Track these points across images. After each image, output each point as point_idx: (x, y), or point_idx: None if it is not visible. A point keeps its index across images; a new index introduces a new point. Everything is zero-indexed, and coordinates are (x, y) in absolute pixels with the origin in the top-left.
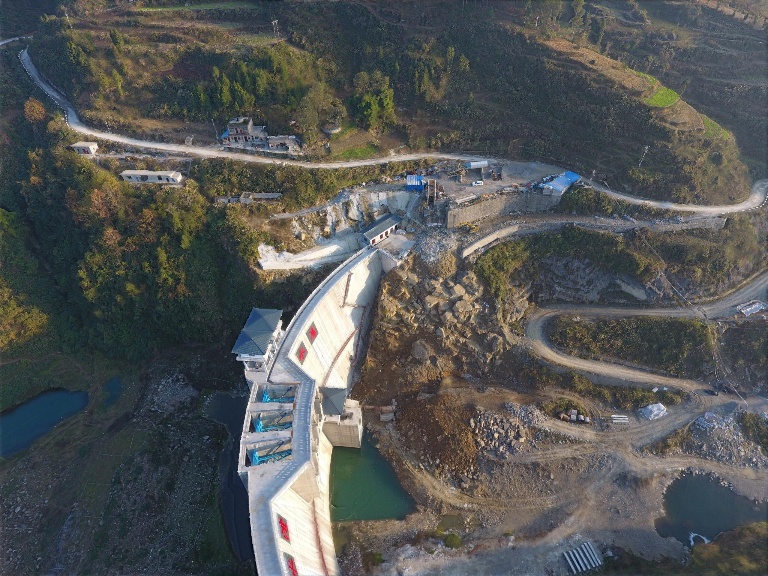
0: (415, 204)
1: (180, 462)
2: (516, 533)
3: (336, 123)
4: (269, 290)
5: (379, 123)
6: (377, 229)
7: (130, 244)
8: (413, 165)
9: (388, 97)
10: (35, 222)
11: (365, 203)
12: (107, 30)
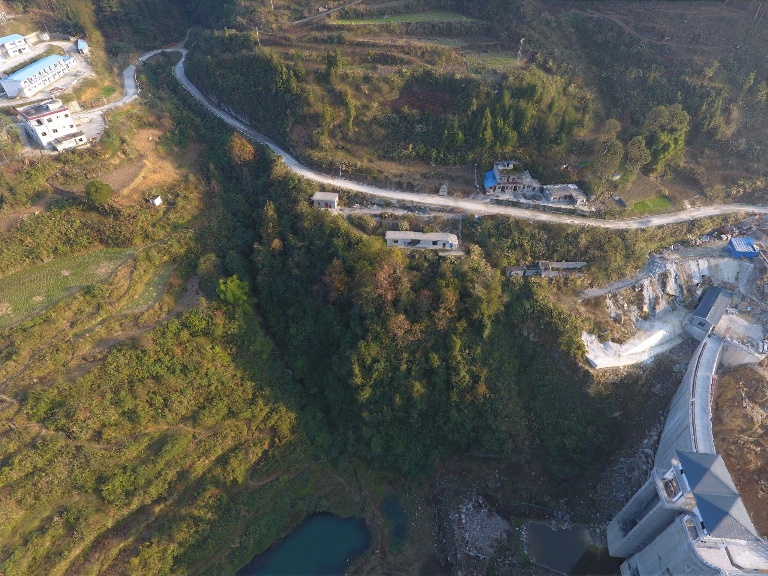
0: (750, 276)
1: None
2: None
3: (634, 170)
4: (597, 393)
5: (662, 166)
6: (716, 311)
7: (417, 332)
8: (721, 221)
9: (682, 136)
10: (262, 291)
11: (683, 273)
12: (306, 48)
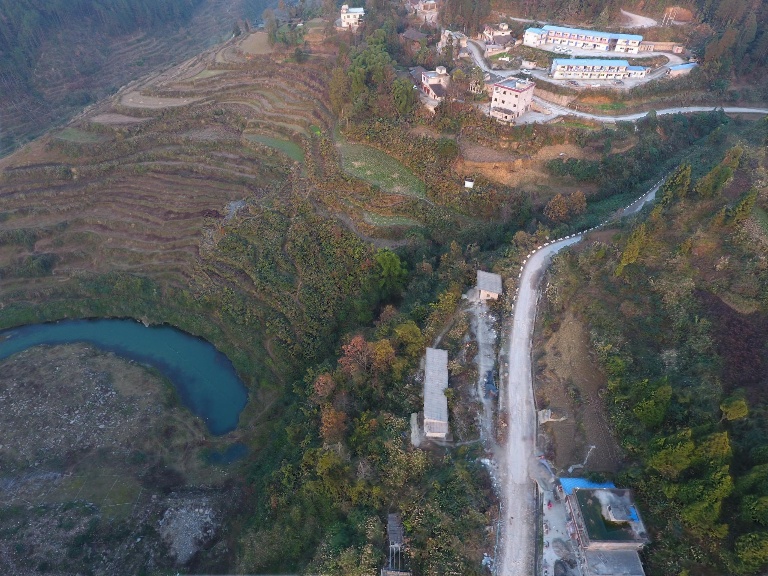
0: None
1: (74, 570)
2: None
3: None
4: None
5: None
6: None
7: None
8: None
9: None
10: None
11: None
12: None
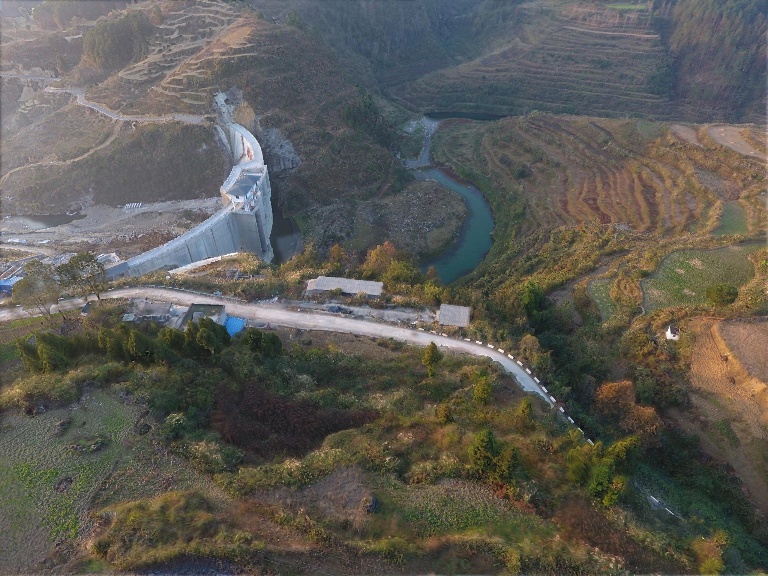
0: None
1: None
2: (155, 215)
3: None
4: None
5: None
6: None
7: None
8: None
9: None
10: None
11: None
12: None
